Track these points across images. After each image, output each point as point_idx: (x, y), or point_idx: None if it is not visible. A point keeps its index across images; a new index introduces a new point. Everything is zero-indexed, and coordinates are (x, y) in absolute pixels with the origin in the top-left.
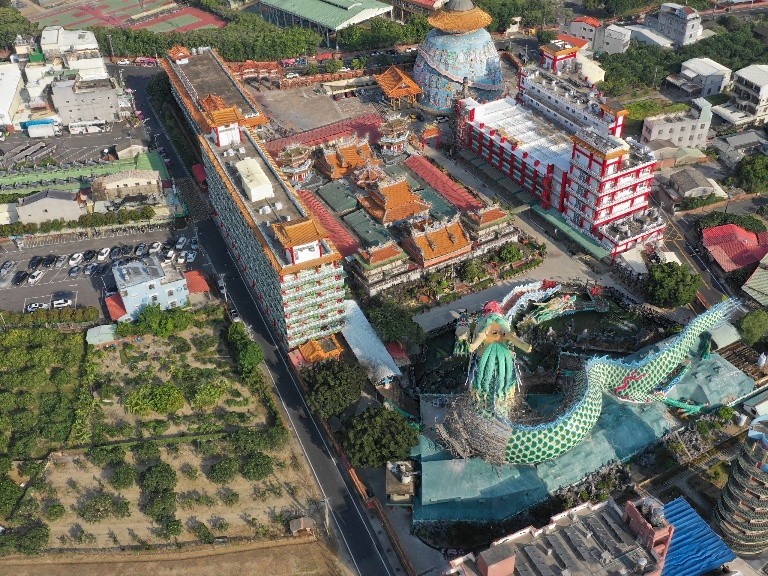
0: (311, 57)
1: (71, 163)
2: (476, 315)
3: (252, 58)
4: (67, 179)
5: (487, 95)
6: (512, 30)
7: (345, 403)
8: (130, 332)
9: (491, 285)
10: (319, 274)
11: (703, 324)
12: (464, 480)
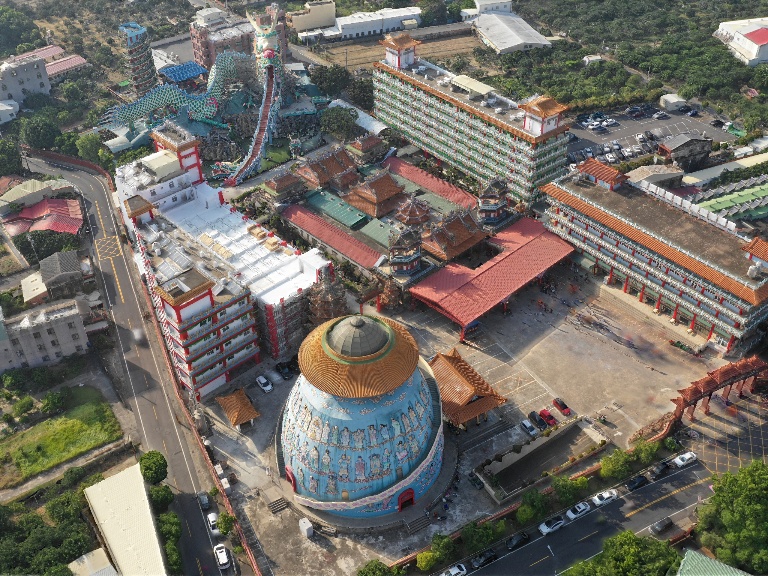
0: None
1: None
2: (289, 161)
3: None
4: None
5: None
6: None
7: None
8: None
9: None
10: None
11: None
12: None
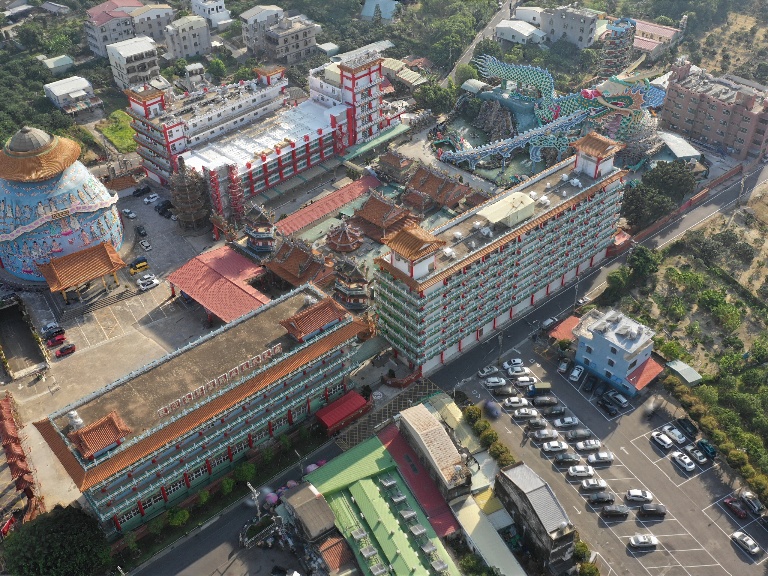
0: None
1: None
2: (494, 182)
3: None
4: (423, 567)
5: None
6: None
7: None
8: None
9: None
10: None
11: None
12: (678, 142)
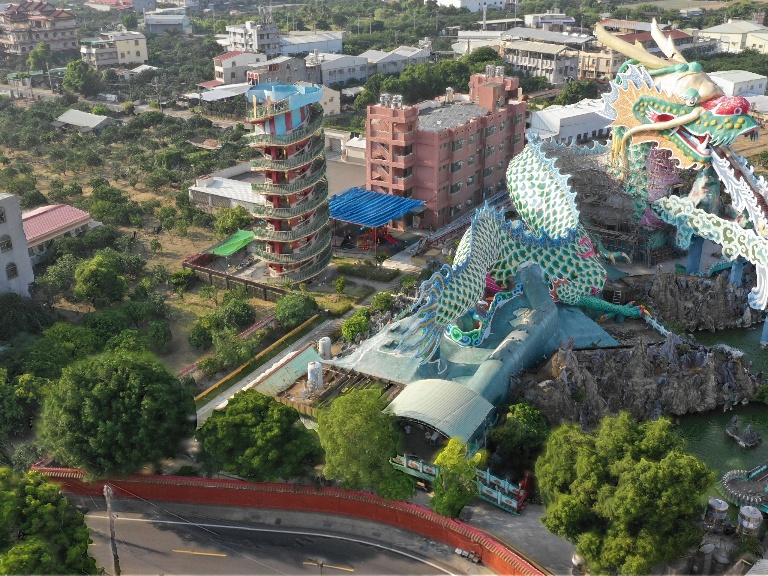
0: None
1: None
2: None
3: None
4: None
5: None
6: None
7: None
8: None
9: None
10: None
11: None
12: None
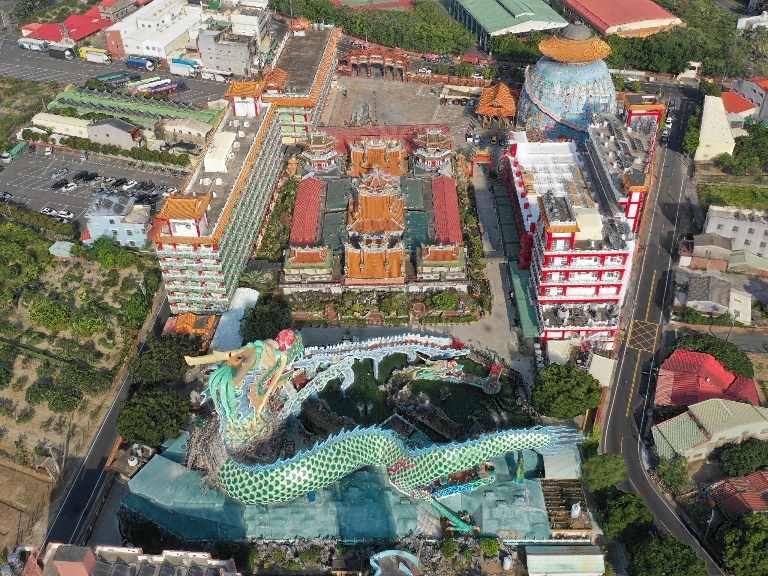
0: (457, 57)
1: (176, 102)
2: None
3: (400, 46)
4: None
5: (581, 136)
6: (688, 75)
7: (156, 377)
8: (80, 254)
9: (405, 325)
10: (195, 252)
11: (515, 441)
12: (170, 486)
